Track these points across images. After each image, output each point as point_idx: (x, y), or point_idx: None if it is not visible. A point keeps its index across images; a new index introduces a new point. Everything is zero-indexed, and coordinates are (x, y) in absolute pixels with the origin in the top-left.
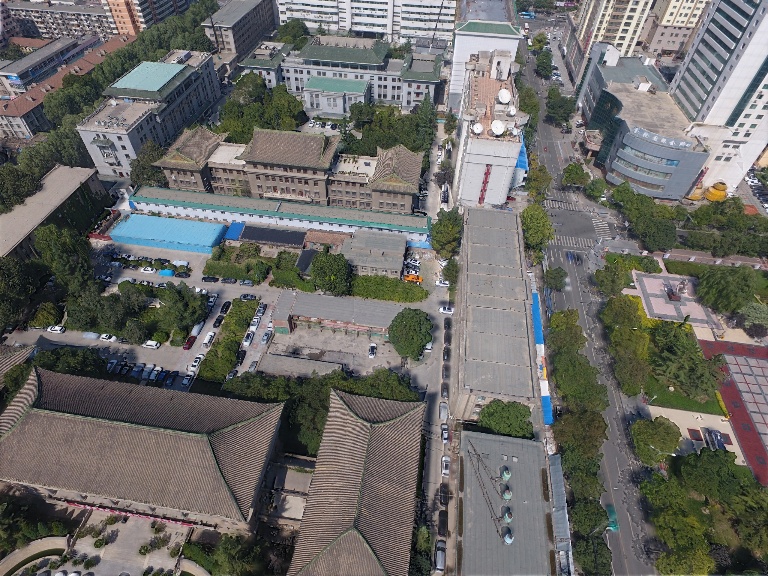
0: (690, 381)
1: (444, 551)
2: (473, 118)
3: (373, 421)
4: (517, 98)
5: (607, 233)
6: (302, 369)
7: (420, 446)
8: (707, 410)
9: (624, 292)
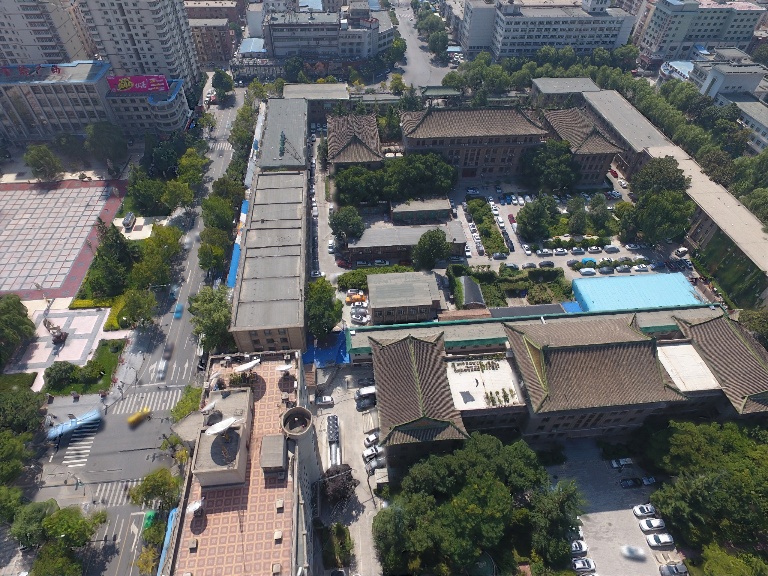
0: None
1: (312, 163)
2: (291, 411)
3: (355, 143)
4: (164, 569)
5: (79, 434)
6: (418, 205)
7: None
8: None
9: (118, 333)
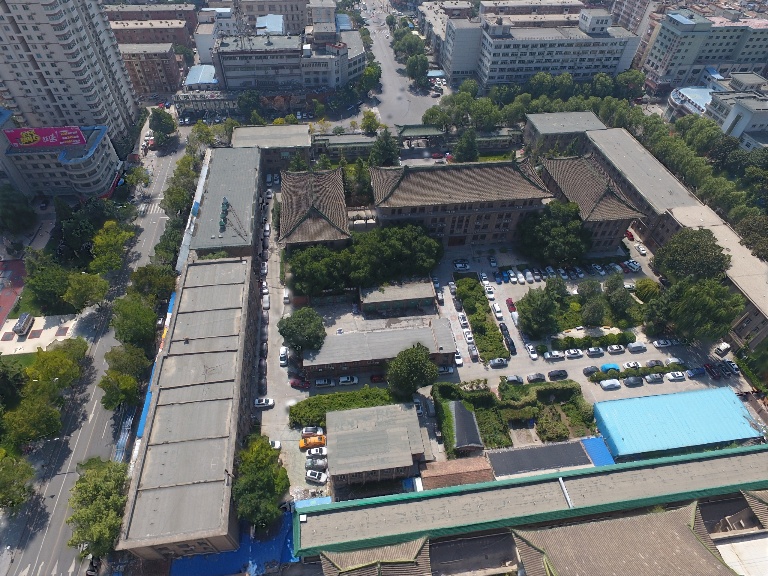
0: (5, 361)
1: (265, 230)
2: None
3: (313, 215)
4: None
5: None
6: (394, 292)
7: (284, 274)
8: (3, 358)
9: None
